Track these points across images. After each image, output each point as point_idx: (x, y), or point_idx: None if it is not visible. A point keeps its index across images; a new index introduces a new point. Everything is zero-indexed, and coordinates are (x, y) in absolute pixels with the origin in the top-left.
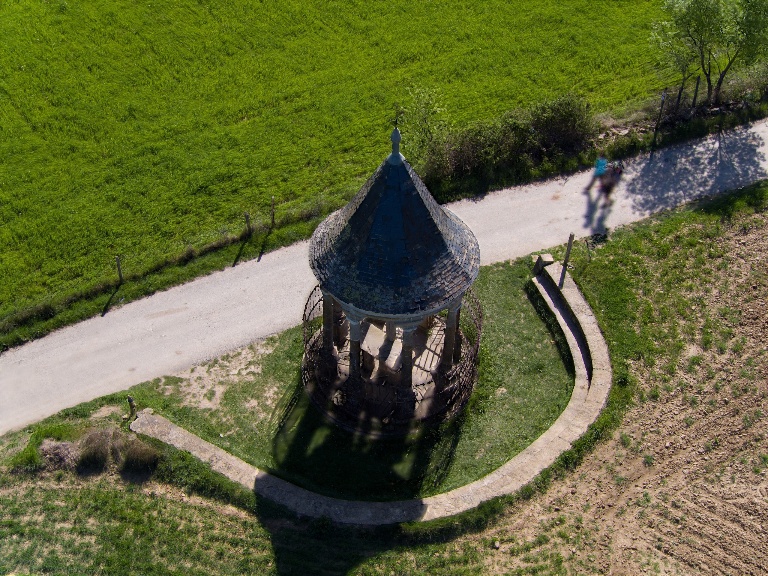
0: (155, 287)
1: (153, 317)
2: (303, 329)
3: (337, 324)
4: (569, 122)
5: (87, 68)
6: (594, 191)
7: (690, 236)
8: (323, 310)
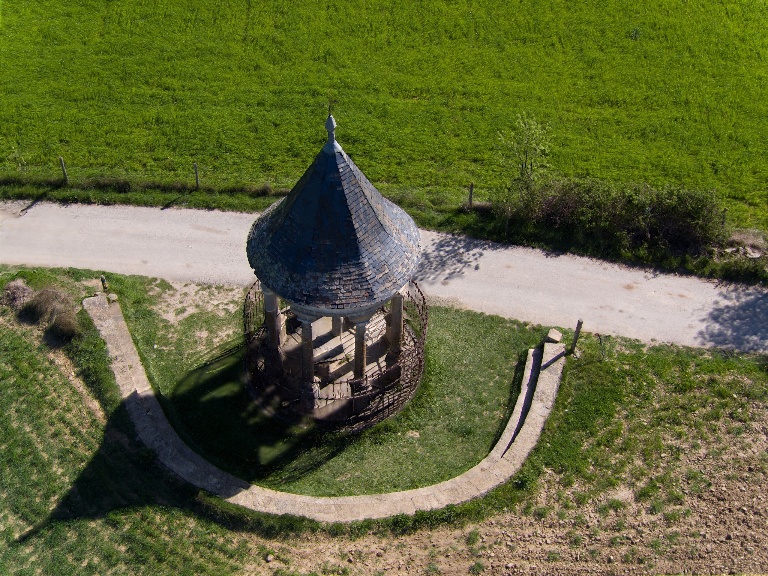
0: (217, 204)
1: (196, 228)
2: (254, 284)
3: None
4: None
5: (327, 6)
6: (674, 298)
7: (728, 386)
8: None
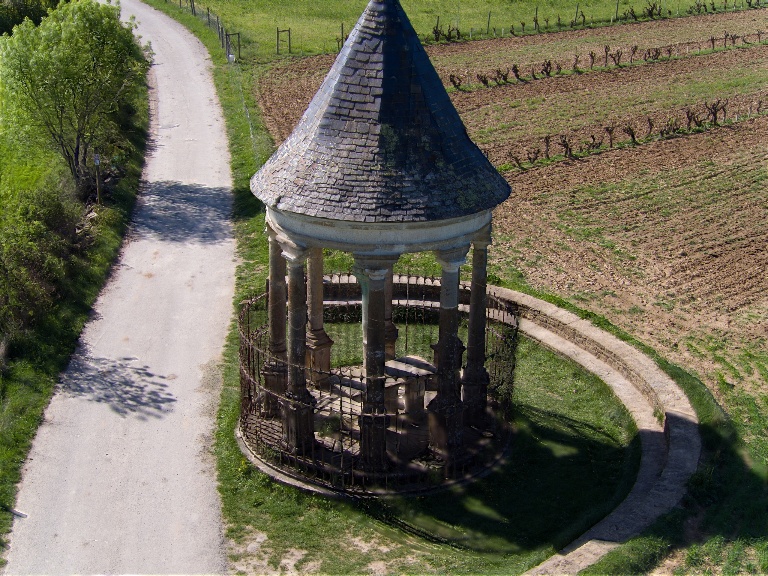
0: None
1: None
2: (361, 381)
3: (314, 403)
4: (66, 210)
5: None
6: (162, 256)
7: None
8: (376, 320)
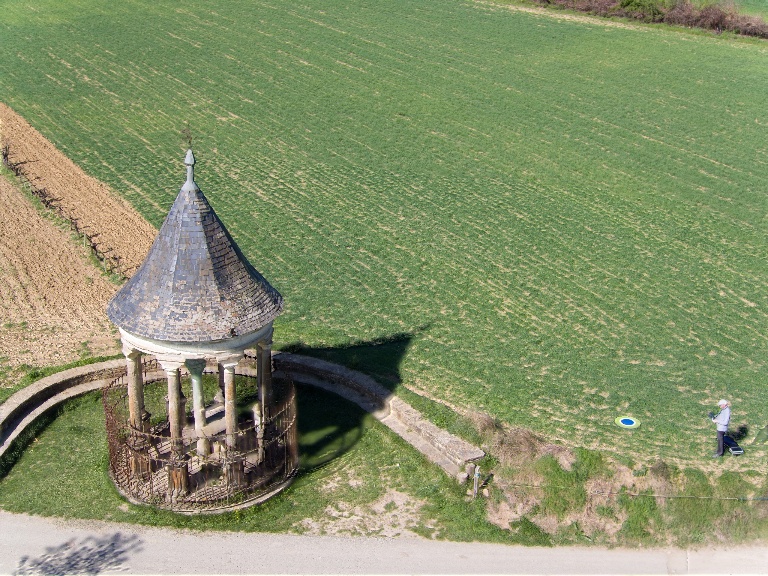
0: None
1: None
2: None
3: None
4: None
5: None
6: None
7: None
8: None
